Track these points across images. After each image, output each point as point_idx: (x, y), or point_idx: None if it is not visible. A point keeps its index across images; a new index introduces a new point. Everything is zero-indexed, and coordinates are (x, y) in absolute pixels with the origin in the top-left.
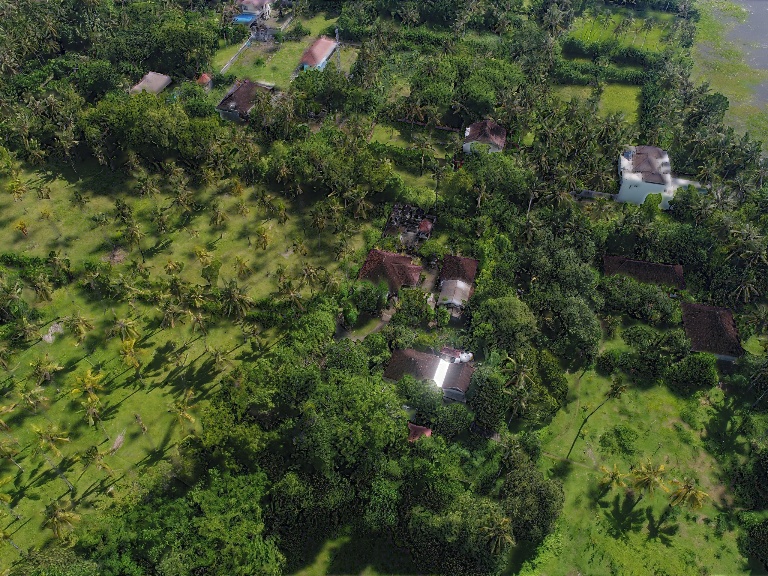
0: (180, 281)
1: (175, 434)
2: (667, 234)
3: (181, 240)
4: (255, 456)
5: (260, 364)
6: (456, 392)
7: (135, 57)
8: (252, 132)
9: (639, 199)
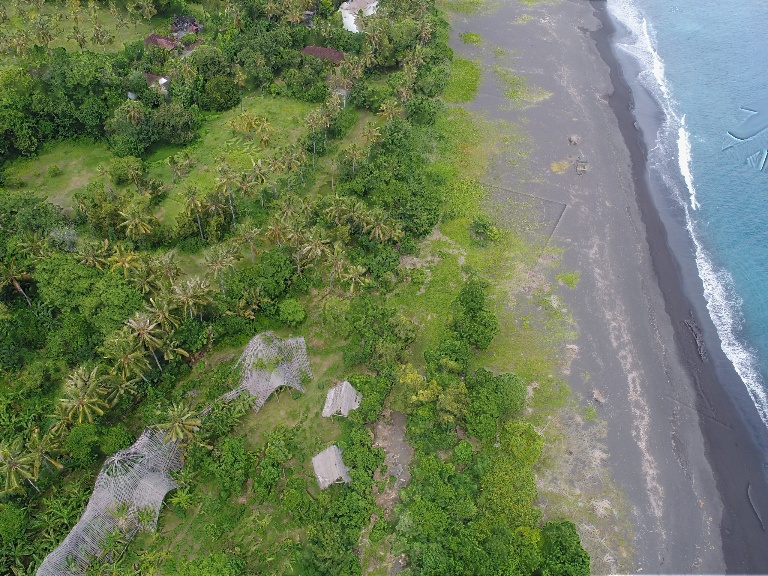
0: None
1: None
2: (340, 35)
3: None
4: (26, 90)
5: None
6: (163, 90)
7: None
8: None
9: (350, 28)
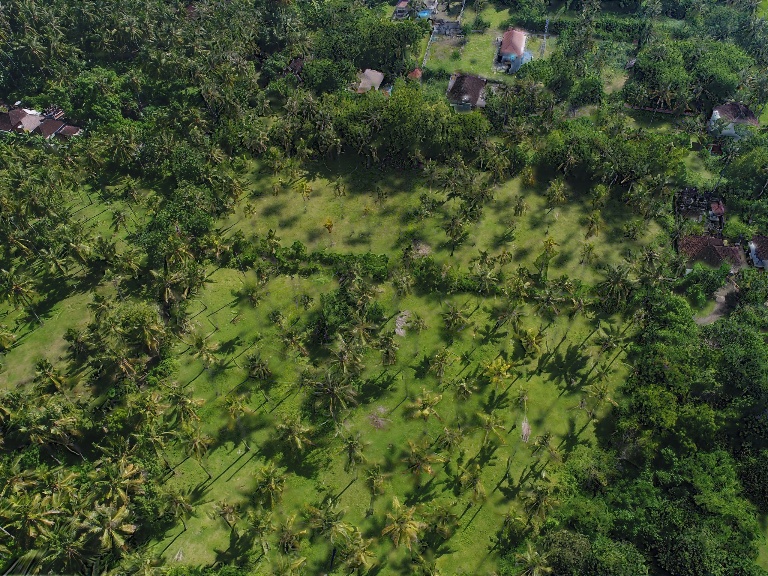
0: (527, 270)
1: (576, 419)
2: None
3: (476, 232)
4: (713, 435)
5: (633, 348)
6: None
7: (352, 55)
8: (488, 124)
9: None
